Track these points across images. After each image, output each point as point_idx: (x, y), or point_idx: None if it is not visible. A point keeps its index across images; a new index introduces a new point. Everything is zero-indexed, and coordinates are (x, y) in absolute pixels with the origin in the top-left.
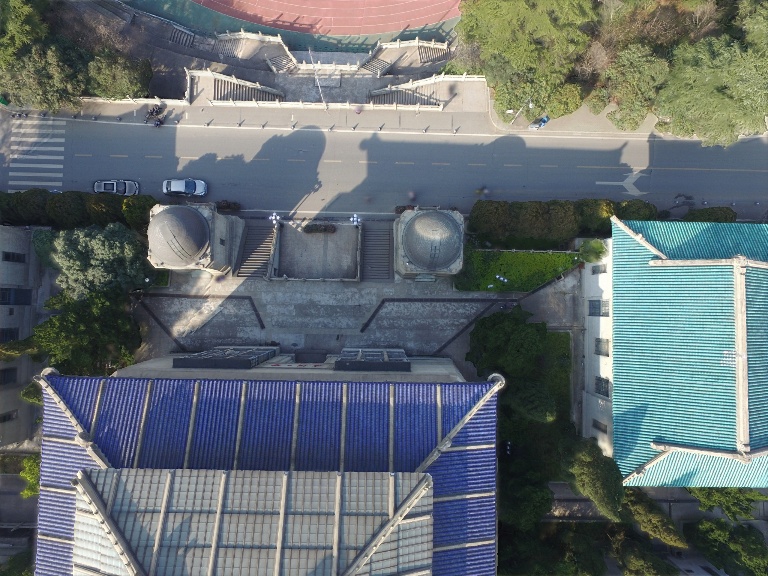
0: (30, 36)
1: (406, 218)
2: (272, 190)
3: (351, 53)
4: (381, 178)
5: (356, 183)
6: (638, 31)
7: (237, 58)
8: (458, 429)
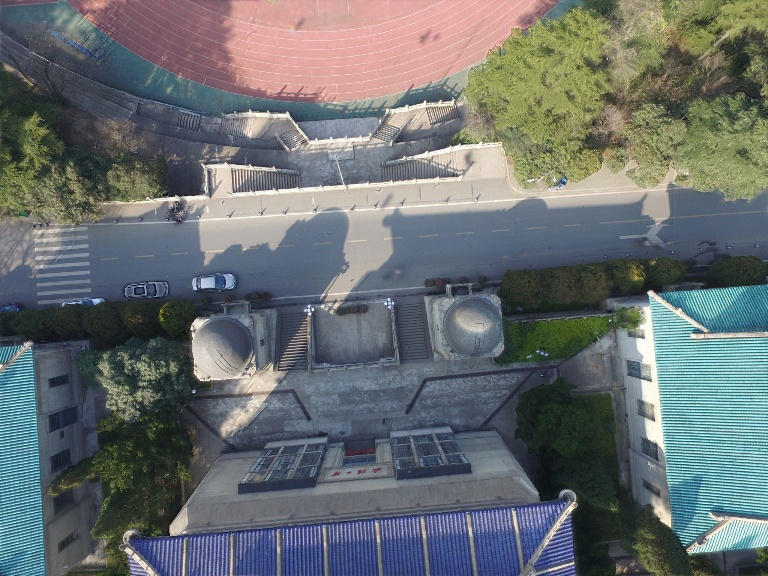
0: (49, 157)
1: (444, 307)
2: (301, 277)
3: (359, 118)
4: (407, 253)
5: (383, 260)
6: (650, 87)
7: (247, 138)
8: (539, 554)
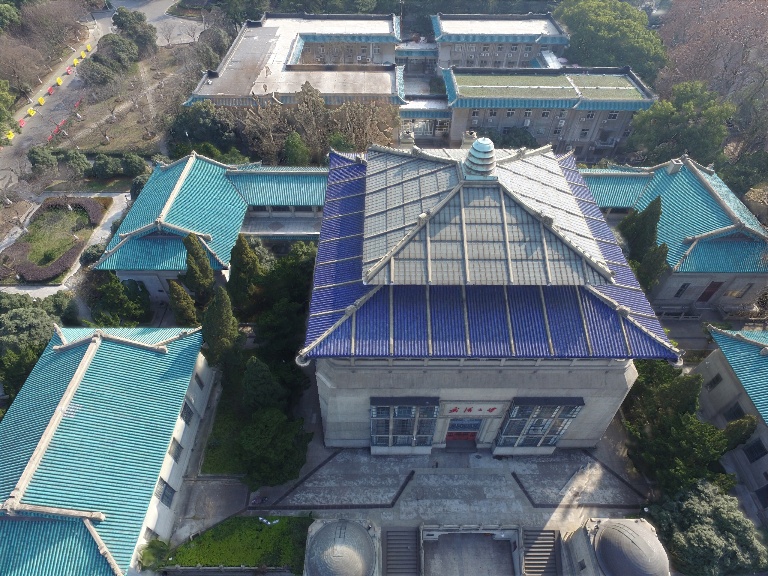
0: None
1: None
2: None
3: None
4: None
5: None
6: None
7: None
8: (339, 321)
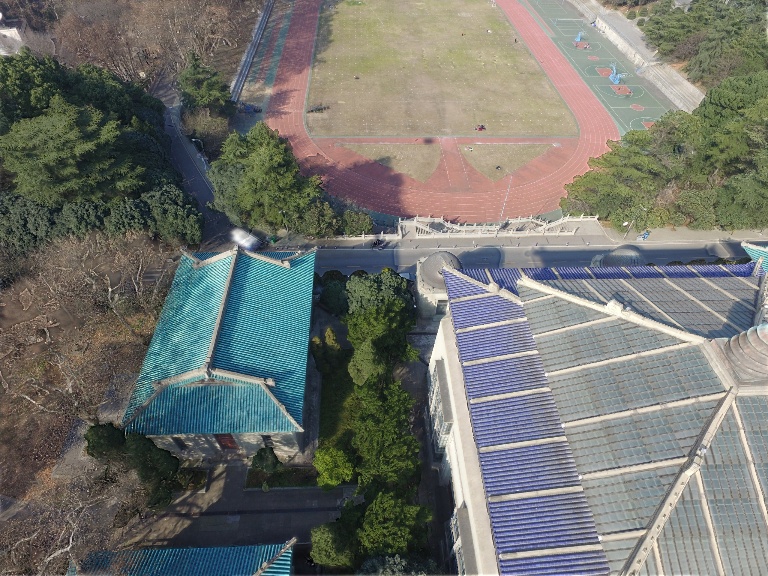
0: (319, 193)
1: (598, 259)
2: None
3: None
4: None
5: None
6: None
7: None
8: None
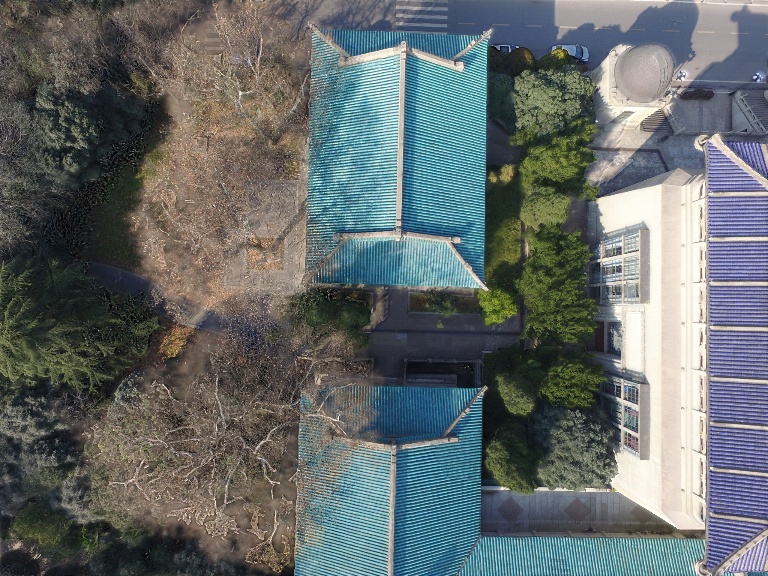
0: None
1: None
2: None
3: None
4: (752, 49)
5: (728, 53)
6: None
7: None
8: None
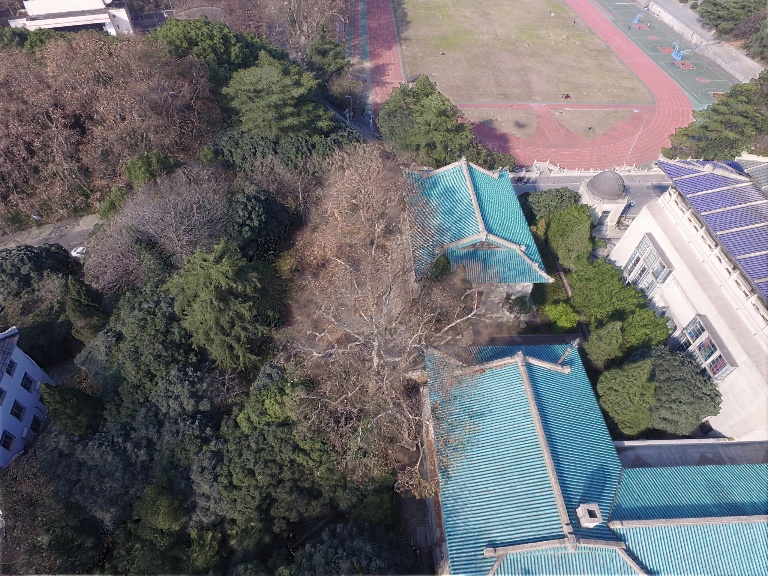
0: None
1: None
2: None
3: None
4: None
5: None
6: None
7: None
8: None
